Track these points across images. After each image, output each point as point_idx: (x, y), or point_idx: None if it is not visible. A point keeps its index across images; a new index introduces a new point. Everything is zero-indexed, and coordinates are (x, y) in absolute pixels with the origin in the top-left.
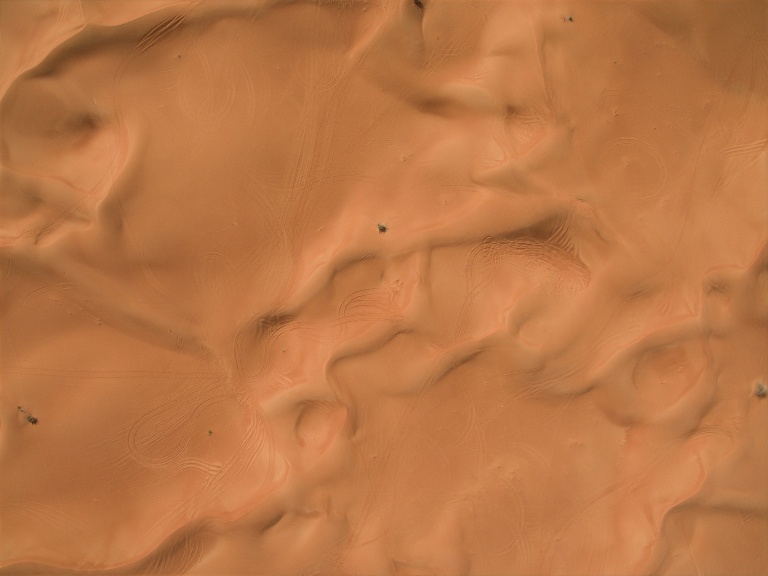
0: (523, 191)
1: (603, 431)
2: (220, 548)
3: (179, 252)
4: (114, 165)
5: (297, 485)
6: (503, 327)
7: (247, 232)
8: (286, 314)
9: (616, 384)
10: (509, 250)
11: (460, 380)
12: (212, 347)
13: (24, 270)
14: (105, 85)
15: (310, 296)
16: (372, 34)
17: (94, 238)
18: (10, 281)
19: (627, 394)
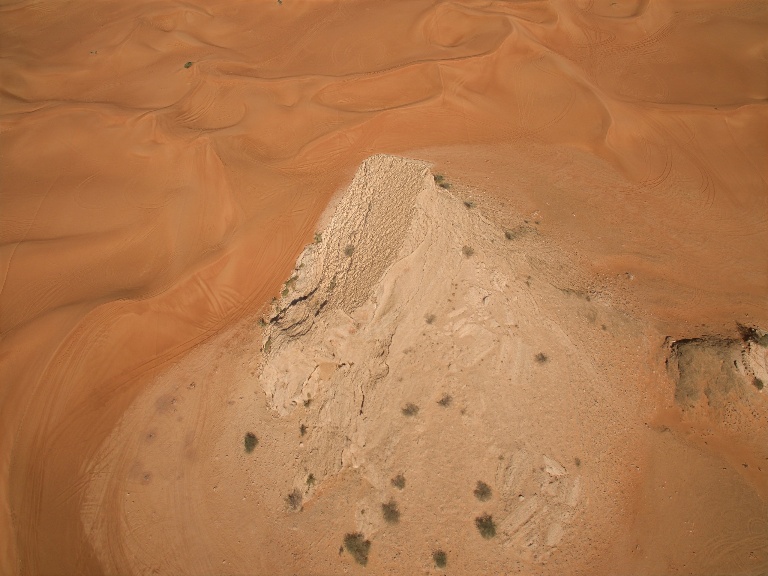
0: (187, 3)
1: None
2: None
3: None
4: (436, 21)
5: None
6: None
7: (363, 7)
8: None
9: None
10: None
11: None
12: None
13: None
14: None
15: None
16: (234, 63)
17: None
18: (513, 0)
19: None
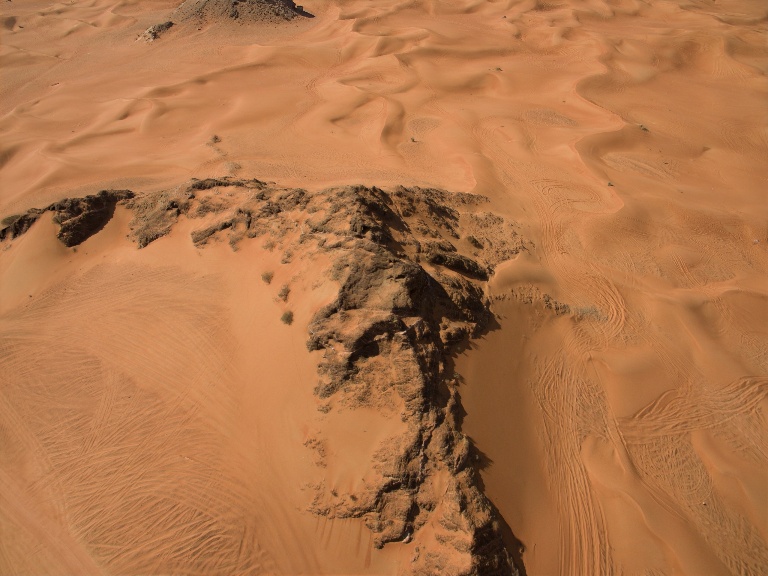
0: None
1: (636, 19)
2: (620, 63)
3: (465, 34)
4: None
5: (602, 38)
6: (572, 10)
7: None
8: (518, 35)
9: (616, 8)
10: (541, 11)
11: (586, 23)
12: (513, 48)
13: (426, 54)
14: (378, 28)
15: (516, 27)
16: (432, 6)
17: (436, 38)
18: (425, 59)
19: (623, 9)
